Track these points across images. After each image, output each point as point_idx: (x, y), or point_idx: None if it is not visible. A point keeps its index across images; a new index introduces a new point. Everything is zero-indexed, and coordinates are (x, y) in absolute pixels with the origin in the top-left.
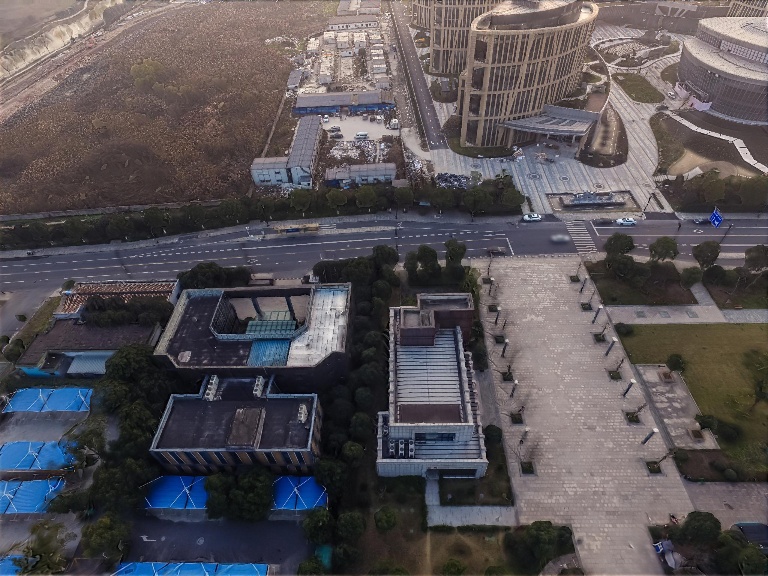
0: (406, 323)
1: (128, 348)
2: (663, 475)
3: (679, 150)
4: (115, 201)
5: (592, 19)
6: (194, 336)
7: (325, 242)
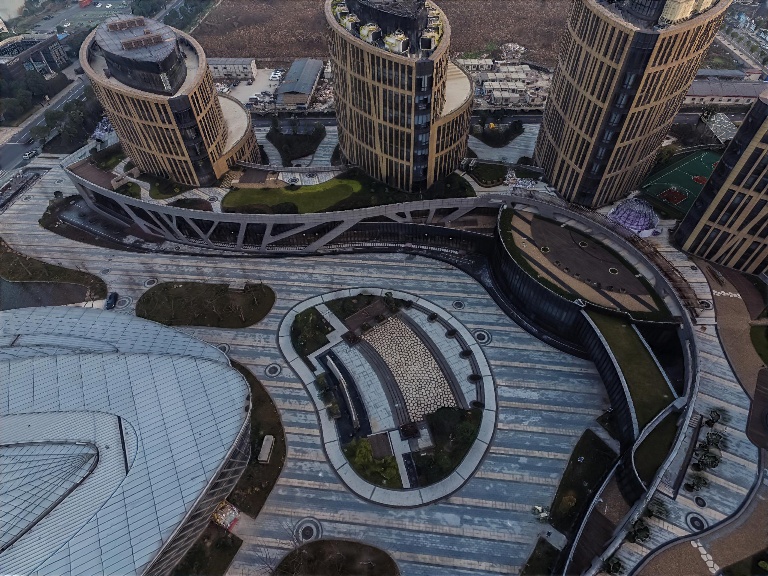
0: None
1: None
2: None
3: (10, 272)
4: (210, 32)
5: (98, 82)
6: None
7: None
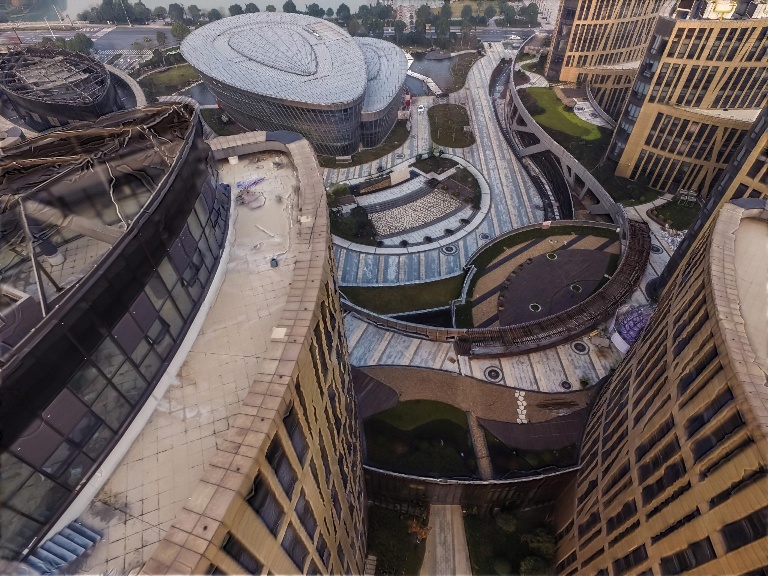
0: None
1: None
2: None
3: None
4: None
5: None
6: None
7: None
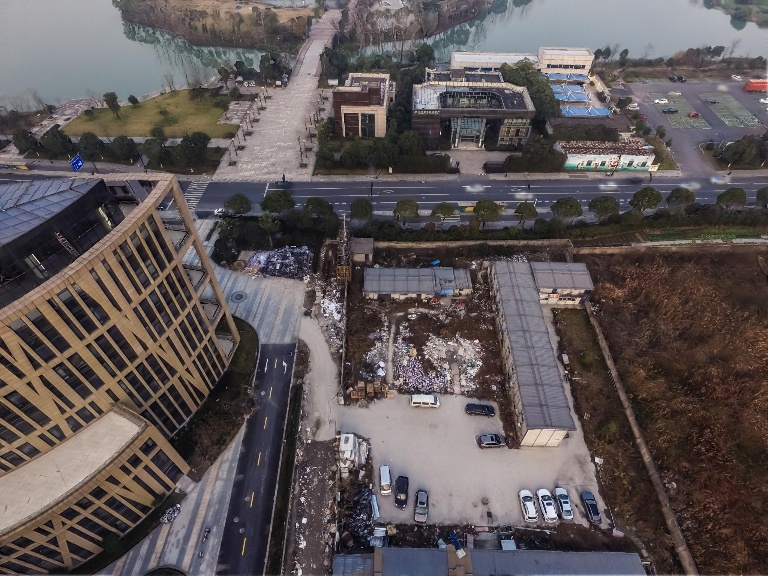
0: (377, 84)
1: (552, 104)
2: (266, 96)
3: None
4: None
5: None
6: (510, 98)
7: (449, 202)
